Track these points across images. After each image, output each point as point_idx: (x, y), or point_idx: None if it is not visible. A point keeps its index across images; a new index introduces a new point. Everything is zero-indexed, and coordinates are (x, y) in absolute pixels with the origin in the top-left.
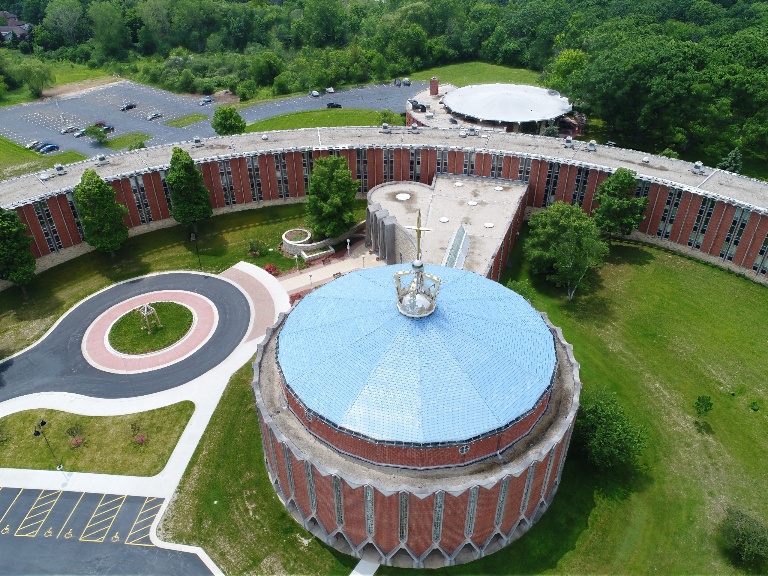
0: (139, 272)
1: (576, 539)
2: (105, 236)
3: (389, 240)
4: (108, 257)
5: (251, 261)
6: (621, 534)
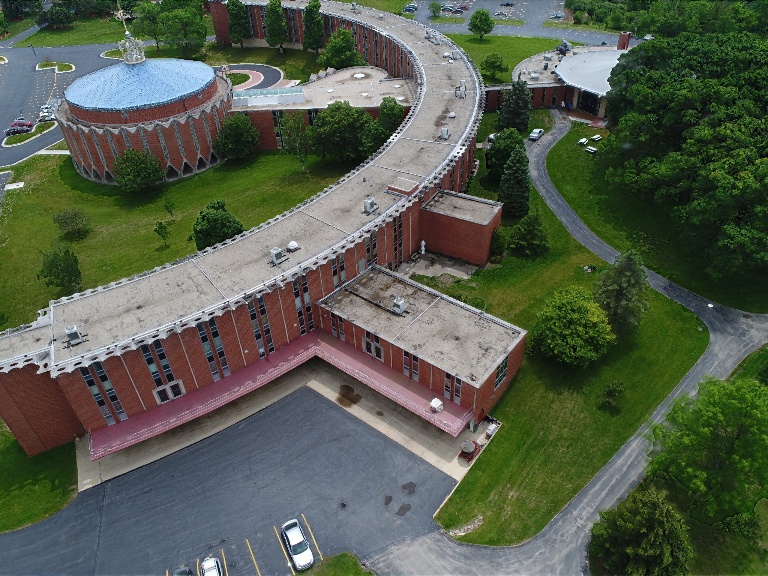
0: (276, 65)
1: (88, 193)
2: (270, 36)
3: None
4: (280, 53)
5: (301, 82)
6: (91, 205)
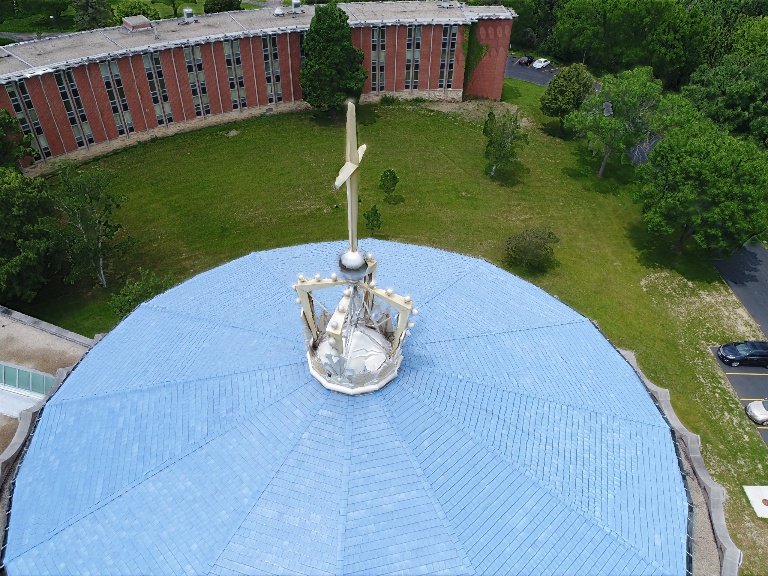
0: None
1: None
2: None
3: None
4: None
5: None
6: None
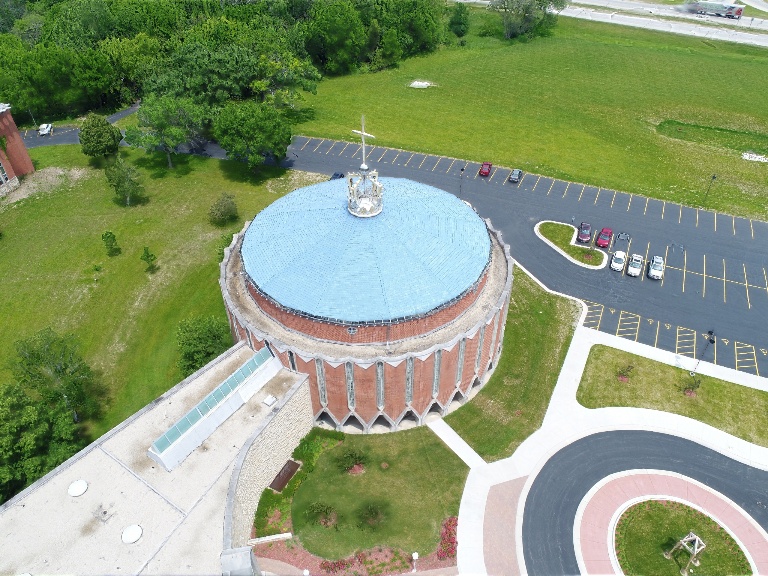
0: None
1: None
2: None
3: None
4: None
5: None
6: None
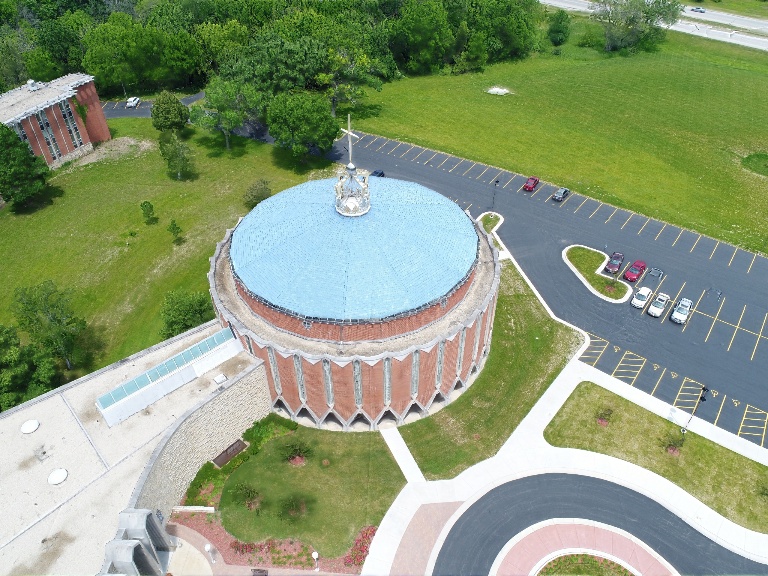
0: None
1: None
2: None
3: (155, 525)
4: None
5: None
6: None
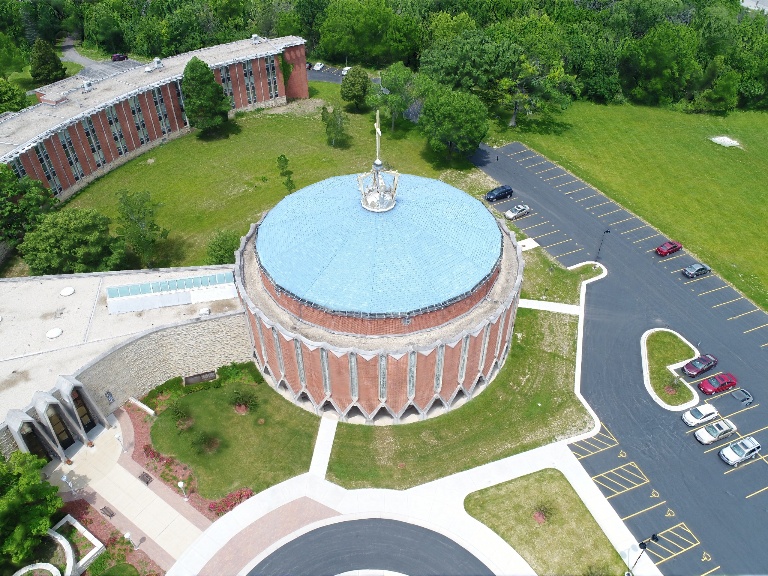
0: None
1: None
2: None
3: None
4: None
5: None
6: None
